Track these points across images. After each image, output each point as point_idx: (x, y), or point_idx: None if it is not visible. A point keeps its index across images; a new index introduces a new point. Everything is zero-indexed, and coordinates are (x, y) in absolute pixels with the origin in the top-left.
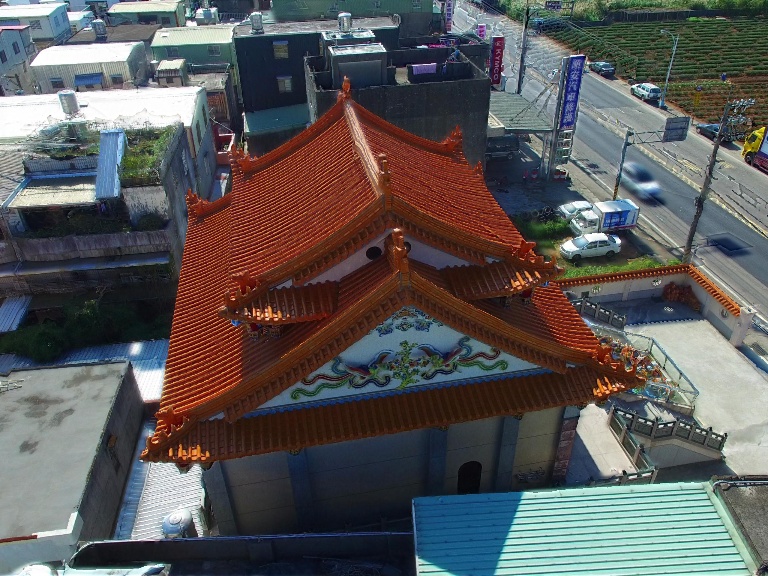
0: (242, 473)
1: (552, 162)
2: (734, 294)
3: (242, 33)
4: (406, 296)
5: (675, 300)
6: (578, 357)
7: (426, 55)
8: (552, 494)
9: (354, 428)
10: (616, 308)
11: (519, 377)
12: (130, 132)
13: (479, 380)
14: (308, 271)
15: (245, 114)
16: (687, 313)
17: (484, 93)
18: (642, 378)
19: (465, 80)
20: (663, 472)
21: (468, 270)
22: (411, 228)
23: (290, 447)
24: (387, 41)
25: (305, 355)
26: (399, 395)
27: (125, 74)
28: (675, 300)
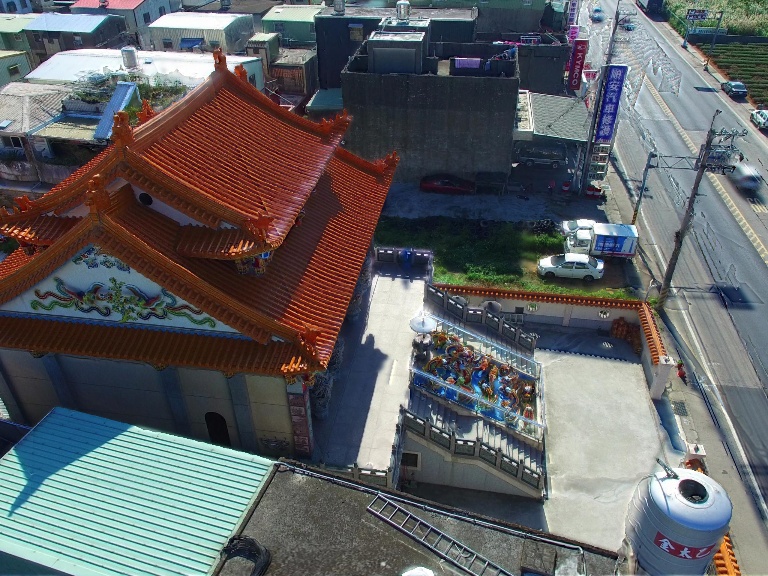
0: (15, 366)
1: (585, 176)
2: (698, 346)
3: (325, 13)
4: (91, 234)
5: (622, 337)
6: (286, 333)
7: (486, 50)
8: (152, 434)
9: (68, 344)
10: (550, 331)
11: (229, 338)
12: (163, 88)
13: (192, 332)
14: (65, 204)
15: (319, 90)
16: (625, 353)
17: (511, 93)
18: (322, 364)
19: (491, 77)
20: (470, 493)
21: (205, 230)
22: (141, 180)
23: (14, 346)
24: (461, 33)
25: (33, 271)
26: (121, 327)
27: (222, 41)
28: (622, 337)
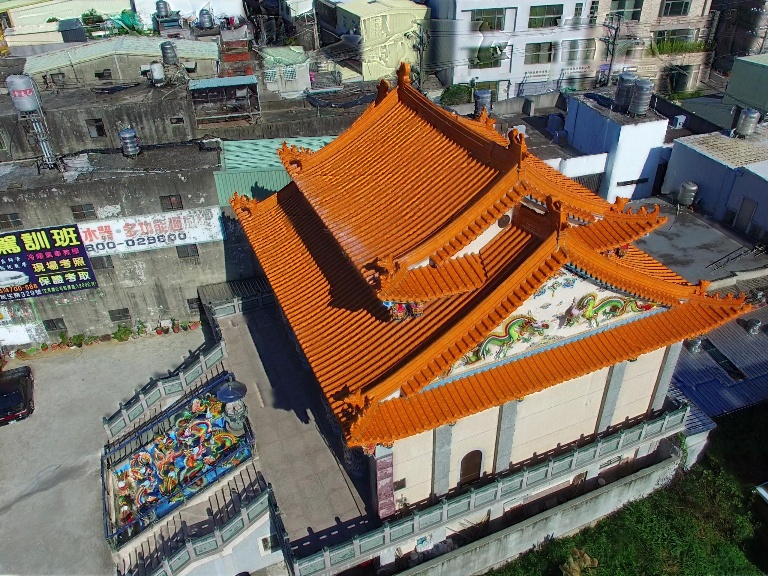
0: None
1: None
2: None
3: None
4: None
5: None
6: None
7: None
8: None
9: None
10: None
11: None
12: None
13: None
14: None
15: None
16: None
17: None
18: None
19: None
20: None
21: None
22: None
23: None
24: None
25: None
26: None
27: None
28: None
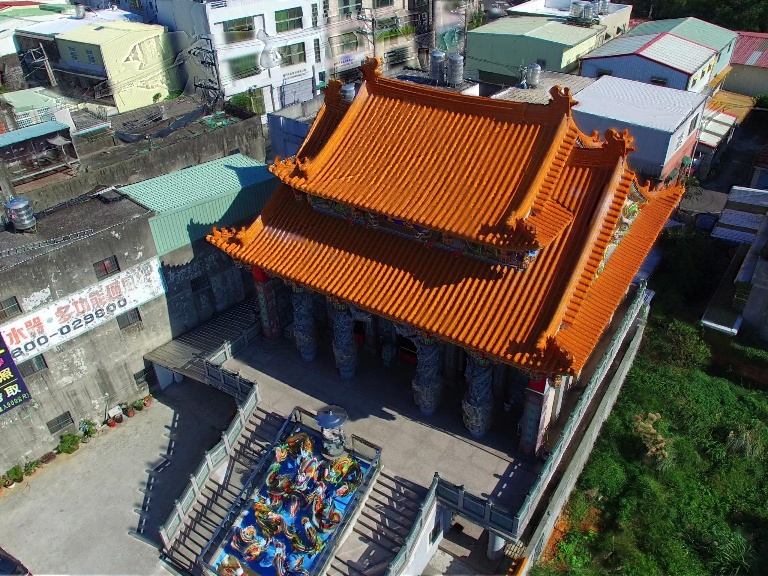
0: None
1: None
2: None
3: None
4: None
5: None
6: None
7: None
8: None
9: None
10: None
11: None
12: None
13: None
14: None
15: None
16: None
17: None
18: (209, 235)
19: None
20: None
21: None
22: None
23: None
24: None
25: None
26: None
27: None
28: None
